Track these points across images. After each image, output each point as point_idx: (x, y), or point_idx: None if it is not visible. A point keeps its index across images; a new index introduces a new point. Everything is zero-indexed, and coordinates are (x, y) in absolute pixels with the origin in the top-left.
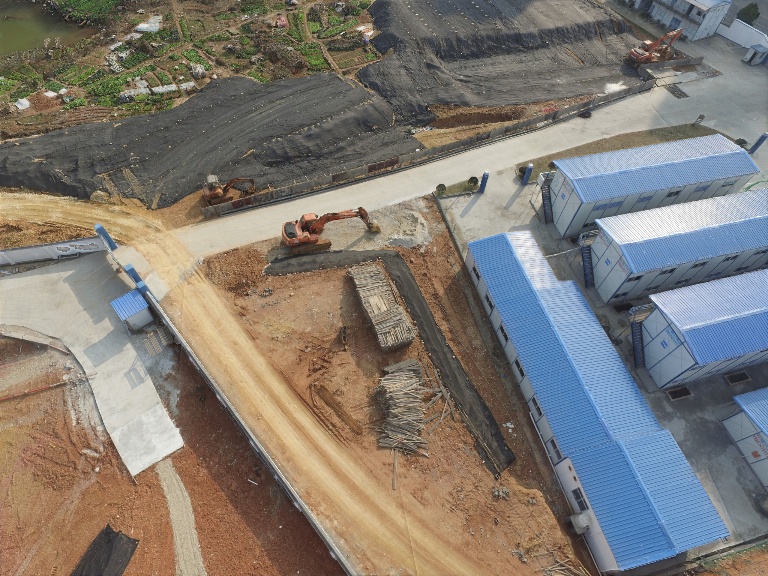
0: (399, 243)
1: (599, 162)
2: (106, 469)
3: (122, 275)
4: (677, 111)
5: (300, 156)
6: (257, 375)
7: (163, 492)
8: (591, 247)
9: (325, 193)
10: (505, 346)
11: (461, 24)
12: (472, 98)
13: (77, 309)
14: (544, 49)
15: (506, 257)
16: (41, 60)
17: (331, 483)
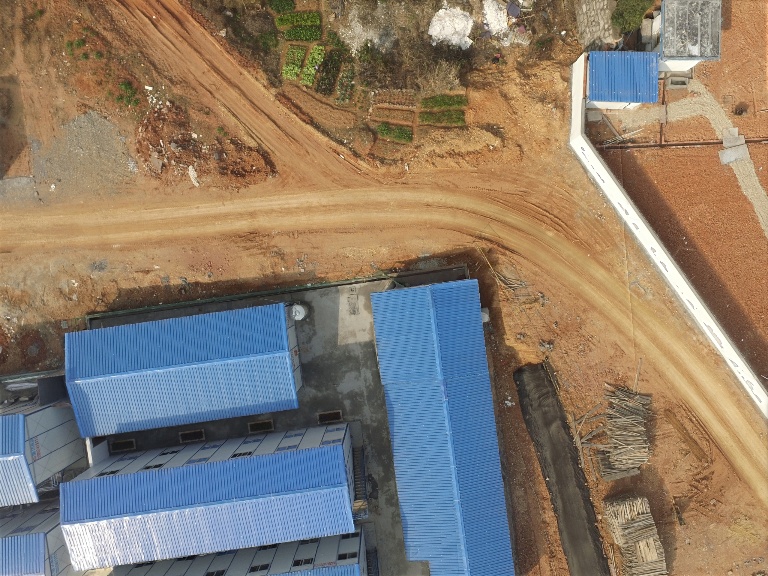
0: None
1: None
2: None
3: None
4: None
5: None
6: (766, 479)
7: None
8: None
9: None
10: None
11: None
12: None
13: None
14: None
15: None
16: None
17: (697, 370)
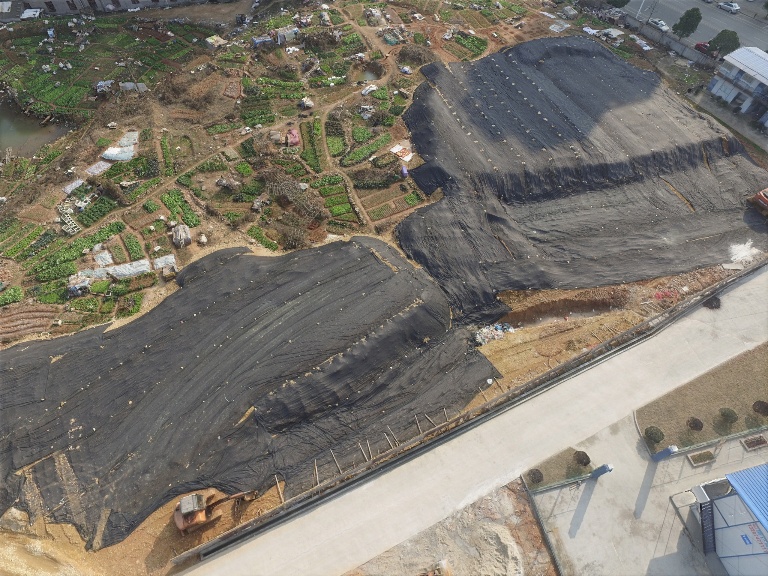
0: None
1: None
2: None
3: None
4: None
5: (323, 409)
6: None
7: None
8: None
9: (362, 487)
10: None
11: (529, 150)
12: (554, 274)
13: None
14: (637, 183)
15: None
16: None
17: None
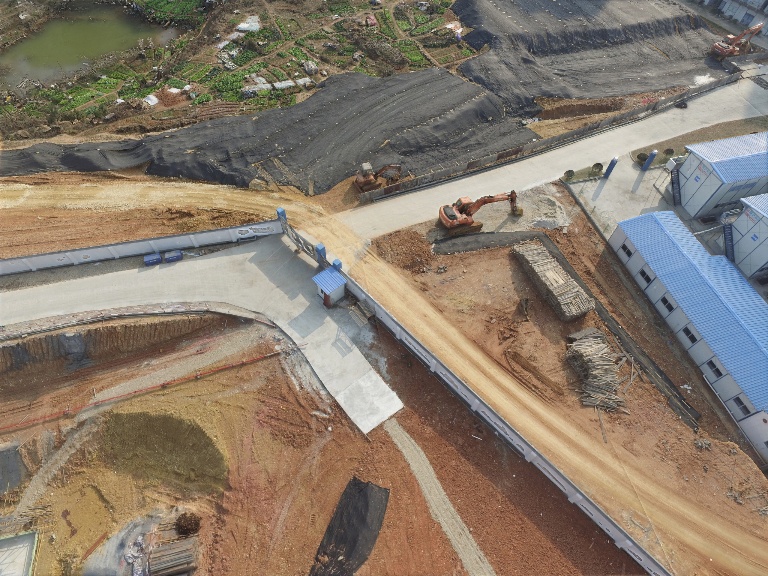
0: (543, 225)
1: (729, 146)
2: (338, 428)
3: (302, 256)
4: (767, 101)
5: (430, 146)
6: (453, 343)
7: (397, 447)
8: (733, 225)
9: (462, 180)
10: (668, 316)
11: (549, 21)
12: (572, 91)
13: (270, 286)
14: (628, 44)
15: (658, 234)
16: (135, 60)
17: (548, 437)
